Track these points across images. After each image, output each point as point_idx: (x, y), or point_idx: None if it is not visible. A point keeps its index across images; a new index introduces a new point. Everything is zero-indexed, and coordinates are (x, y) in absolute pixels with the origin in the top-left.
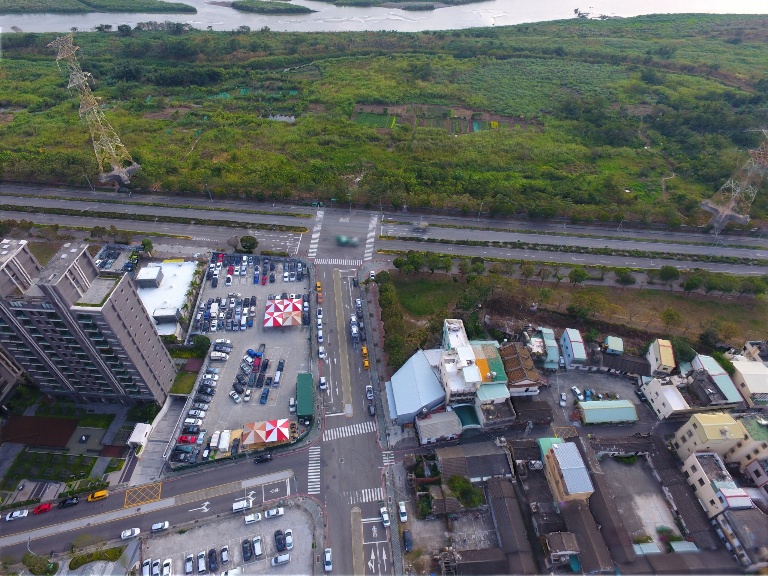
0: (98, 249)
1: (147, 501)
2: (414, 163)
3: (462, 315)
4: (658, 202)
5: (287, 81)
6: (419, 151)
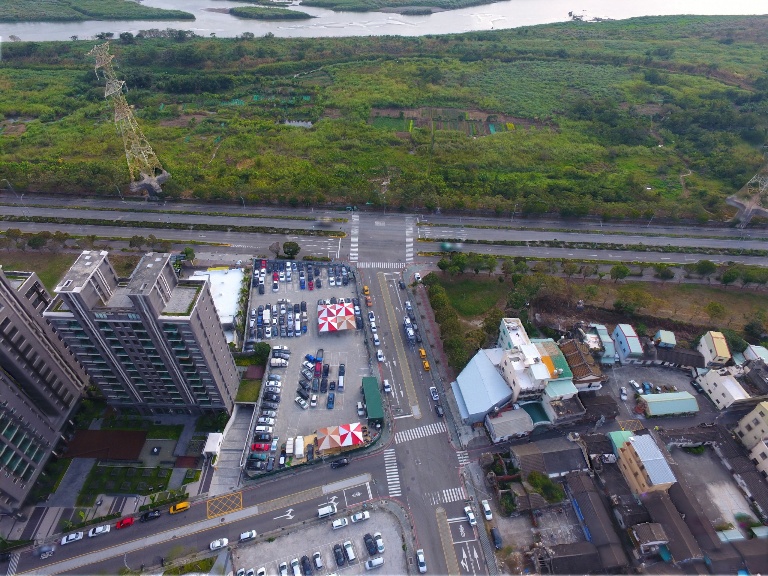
0: (137, 259)
1: (230, 511)
2: (438, 166)
3: (515, 314)
4: (680, 198)
5: (299, 87)
6: (441, 154)
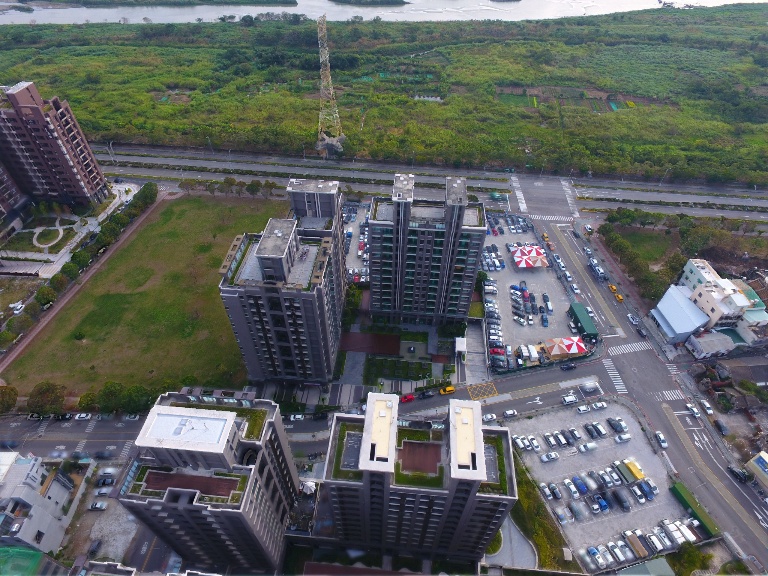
0: None
1: (488, 395)
2: (572, 137)
3: None
4: None
5: (420, 66)
6: (573, 127)
